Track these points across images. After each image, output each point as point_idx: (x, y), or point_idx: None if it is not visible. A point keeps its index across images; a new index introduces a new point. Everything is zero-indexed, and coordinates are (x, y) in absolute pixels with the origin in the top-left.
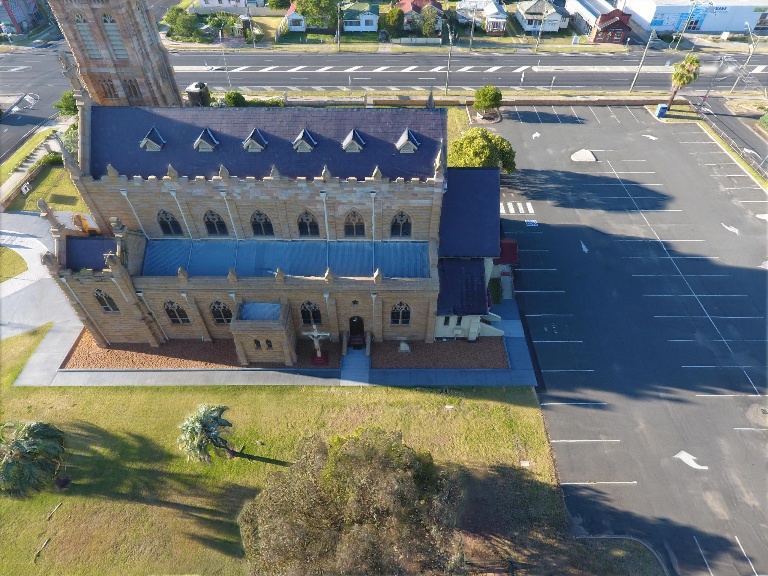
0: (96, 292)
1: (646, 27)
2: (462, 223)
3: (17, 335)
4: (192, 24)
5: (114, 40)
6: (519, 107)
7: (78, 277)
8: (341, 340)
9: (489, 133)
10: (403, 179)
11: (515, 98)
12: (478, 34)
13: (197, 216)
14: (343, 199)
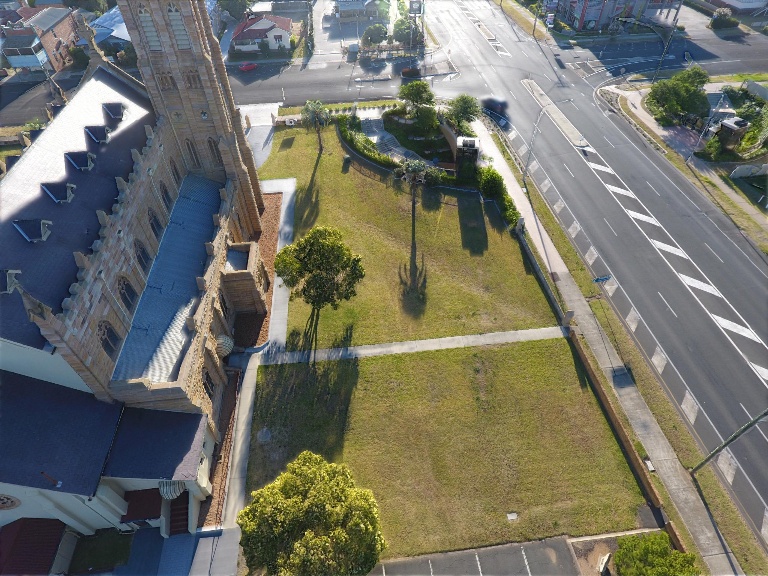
0: None
1: None
2: None
3: None
4: (667, 94)
5: None
6: None
7: None
8: None
9: (336, 535)
10: None
11: None
12: None
13: None
14: None
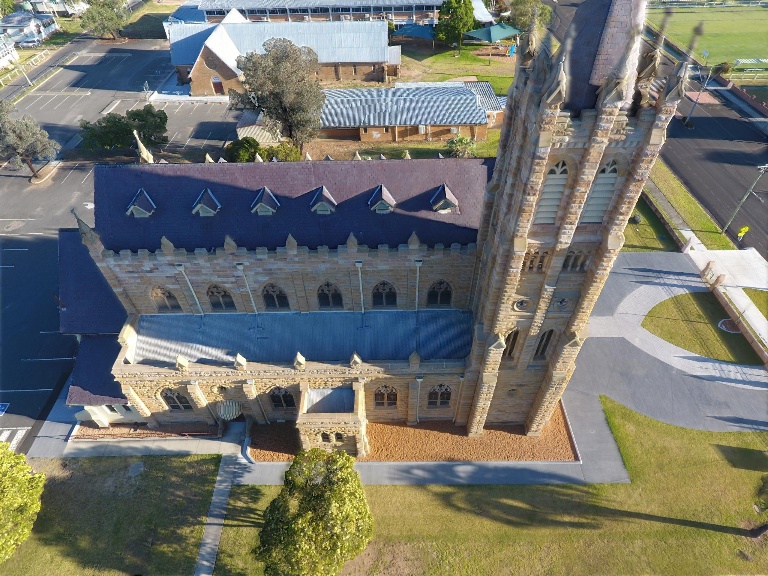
0: None
1: None
2: None
3: None
4: None
5: None
6: None
7: None
8: None
9: None
10: None
11: None
12: None
13: None
14: None
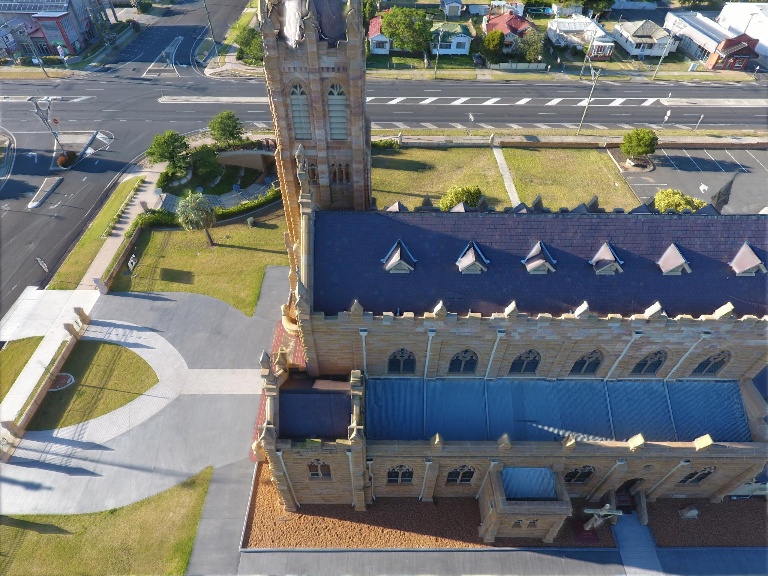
0: (313, 461)
1: (763, 52)
2: None
3: (171, 488)
4: None
5: (335, 116)
6: (667, 151)
7: (300, 449)
8: (603, 500)
9: (689, 197)
10: (757, 318)
11: (658, 139)
12: (580, 58)
13: (446, 355)
14: (658, 339)
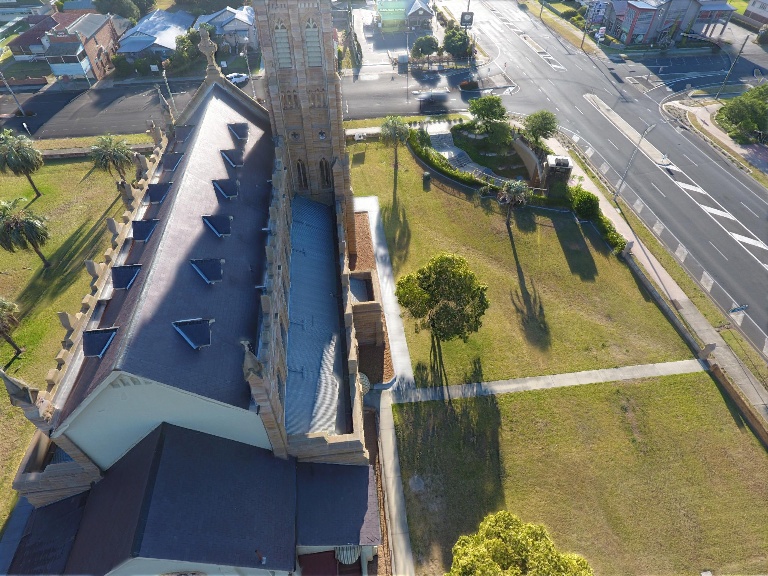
0: None
1: None
2: (103, 510)
3: None
4: (744, 111)
5: None
6: None
7: None
8: None
9: None
10: None
11: None
12: None
13: None
14: None
